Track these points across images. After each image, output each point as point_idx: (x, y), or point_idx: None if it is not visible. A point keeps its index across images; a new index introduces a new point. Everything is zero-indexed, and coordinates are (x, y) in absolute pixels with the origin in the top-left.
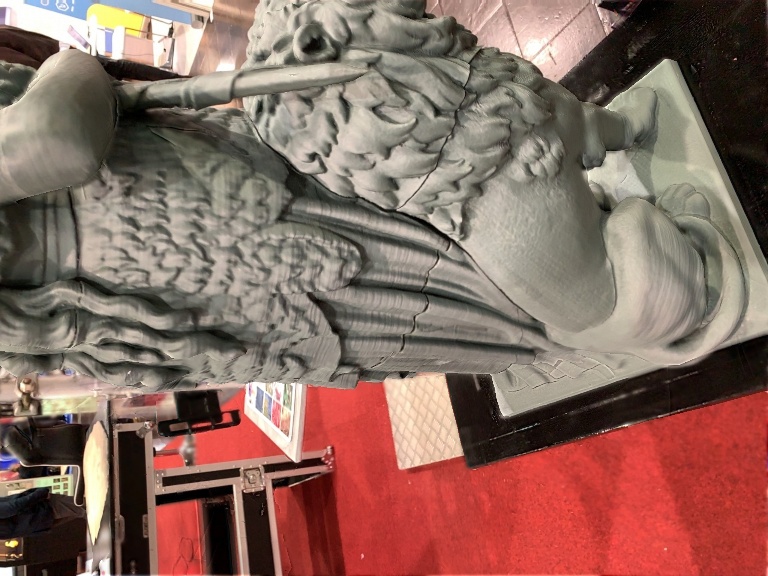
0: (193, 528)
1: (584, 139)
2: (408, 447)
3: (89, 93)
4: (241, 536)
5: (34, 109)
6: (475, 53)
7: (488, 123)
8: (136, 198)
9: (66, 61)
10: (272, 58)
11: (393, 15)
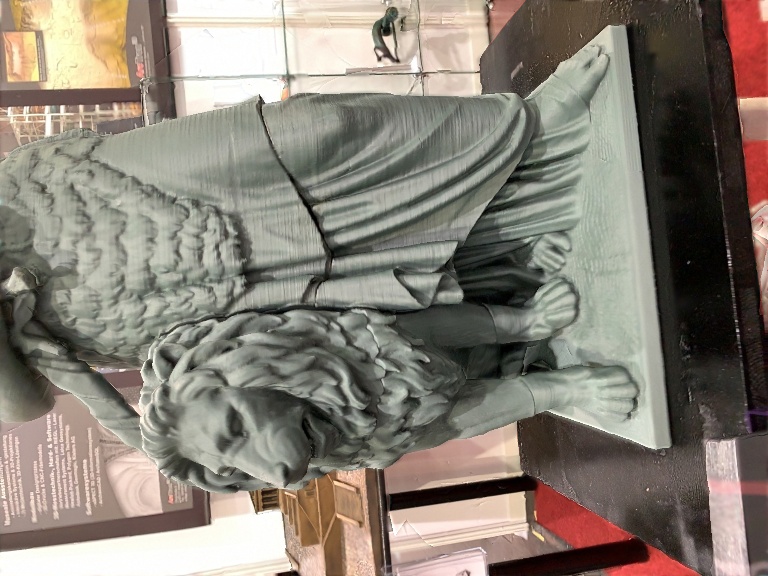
0: None
1: None
2: None
3: None
4: None
5: None
6: None
7: None
8: None
9: None
10: None
11: None
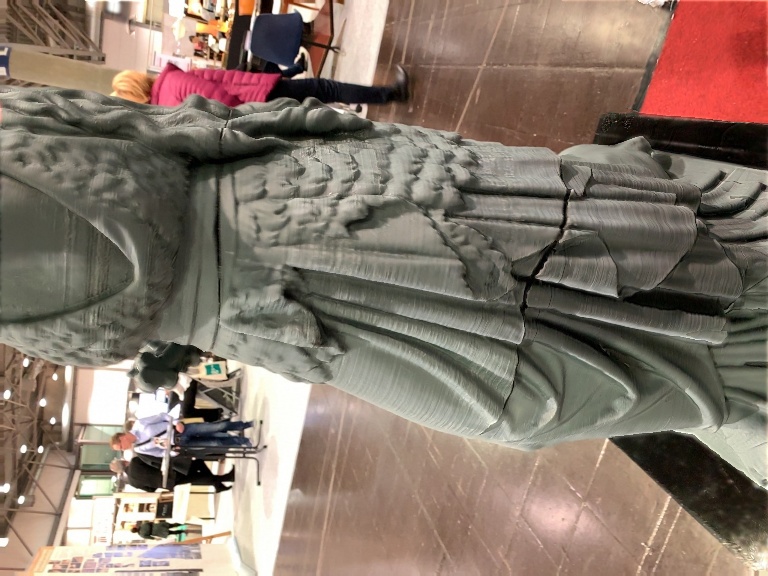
0: None
1: None
2: None
3: None
4: None
5: None
6: None
7: None
8: None
9: None
10: None
11: None
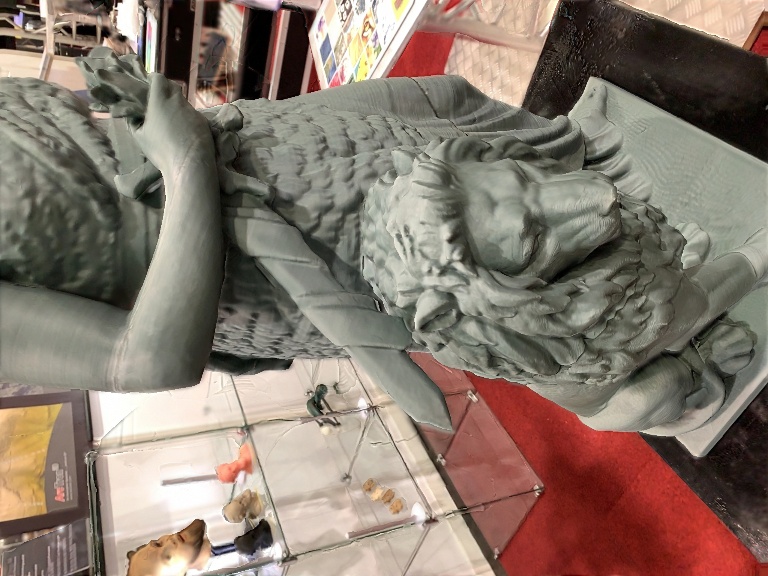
0: (238, 17)
1: (669, 345)
2: (462, 62)
3: (200, 324)
4: (281, 41)
5: (150, 367)
6: (605, 327)
7: (564, 380)
8: (228, 326)
9: (180, 243)
10: (397, 278)
11: (535, 322)
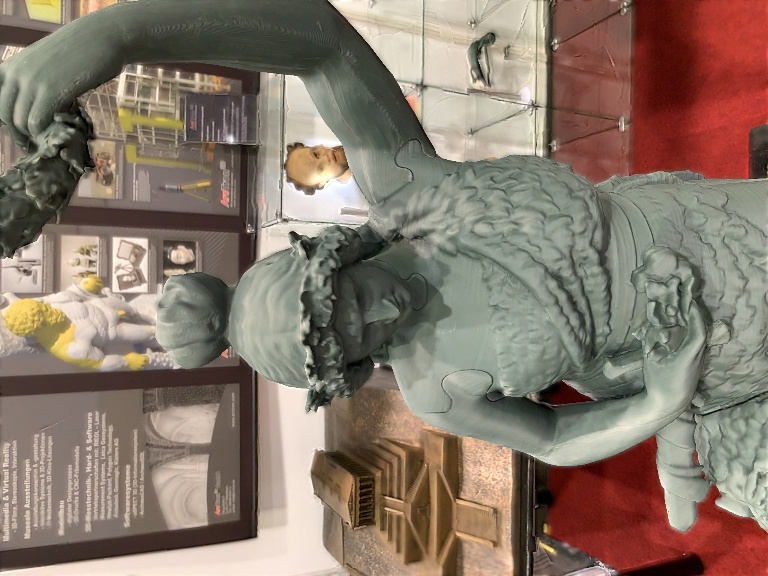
0: None
1: None
2: None
3: None
4: None
5: None
6: None
7: None
8: None
9: (627, 443)
10: (732, 480)
11: None
